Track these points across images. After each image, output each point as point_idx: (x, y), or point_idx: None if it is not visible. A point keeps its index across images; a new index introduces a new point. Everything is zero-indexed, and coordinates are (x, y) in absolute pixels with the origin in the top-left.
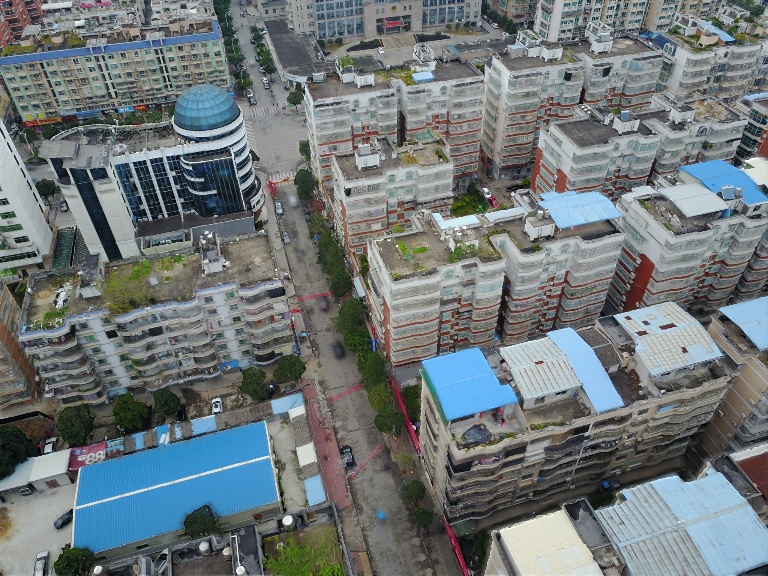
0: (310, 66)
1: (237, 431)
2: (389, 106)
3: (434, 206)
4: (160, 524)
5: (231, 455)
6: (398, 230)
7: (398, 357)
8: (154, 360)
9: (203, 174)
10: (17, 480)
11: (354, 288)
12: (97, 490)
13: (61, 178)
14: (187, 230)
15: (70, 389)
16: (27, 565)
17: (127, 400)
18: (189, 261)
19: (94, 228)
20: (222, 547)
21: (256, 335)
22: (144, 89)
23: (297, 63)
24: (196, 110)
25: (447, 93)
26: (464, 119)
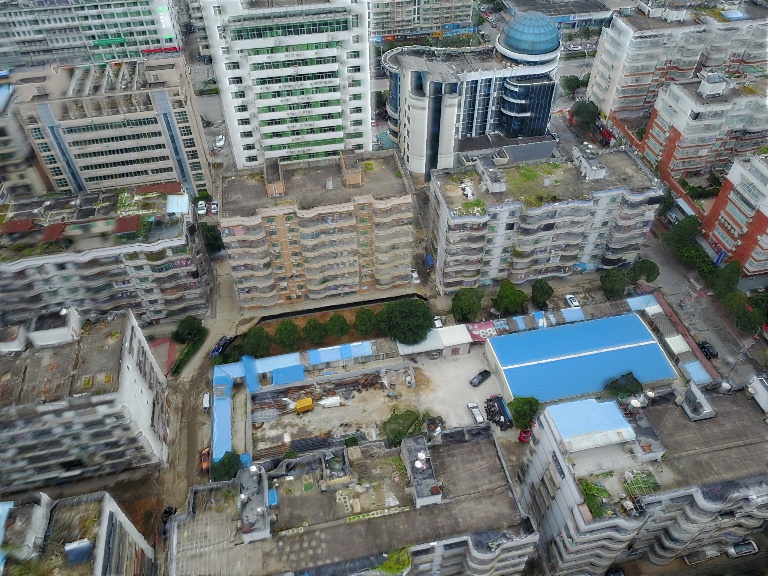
0: (537, 7)
1: (615, 320)
2: (699, 41)
3: (758, 136)
4: (580, 387)
5: (620, 338)
6: (764, 151)
7: (756, 267)
8: (532, 254)
9: (525, 96)
10: (434, 344)
11: (676, 208)
12: (513, 356)
13: (412, 91)
14: (498, 149)
15: (454, 275)
16: (460, 412)
17: (512, 287)
18: (565, 168)
19: (426, 140)
20: (741, 388)
21: (613, 240)
22: (396, 20)
23: (523, 3)
24: (532, 35)
25: (751, 32)
26: (758, 59)
